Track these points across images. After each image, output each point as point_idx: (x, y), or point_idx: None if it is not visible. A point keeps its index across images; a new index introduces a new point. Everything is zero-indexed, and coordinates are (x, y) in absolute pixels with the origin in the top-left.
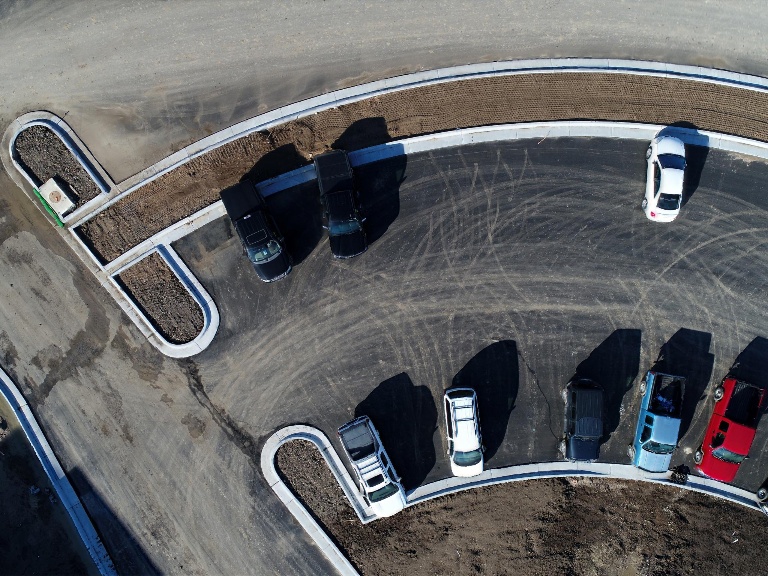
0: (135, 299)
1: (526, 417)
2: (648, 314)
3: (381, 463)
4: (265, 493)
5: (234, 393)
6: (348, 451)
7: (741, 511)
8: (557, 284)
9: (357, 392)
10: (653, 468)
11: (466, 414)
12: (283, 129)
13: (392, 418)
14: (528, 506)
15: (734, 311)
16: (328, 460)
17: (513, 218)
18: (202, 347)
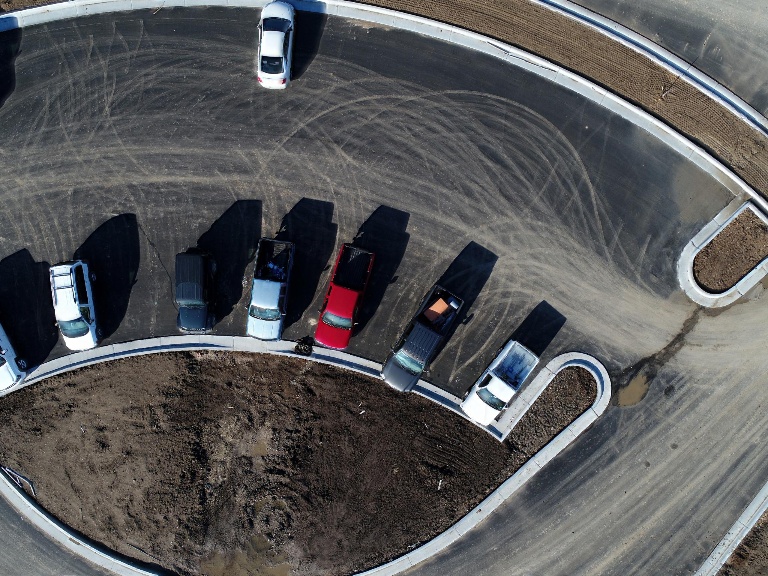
0: None
1: (148, 291)
2: (269, 184)
3: None
4: None
5: None
6: None
7: (368, 382)
8: (176, 156)
9: None
10: (262, 335)
11: (64, 282)
12: None
13: (14, 295)
14: (151, 381)
15: (357, 180)
16: None
17: (130, 90)
18: None
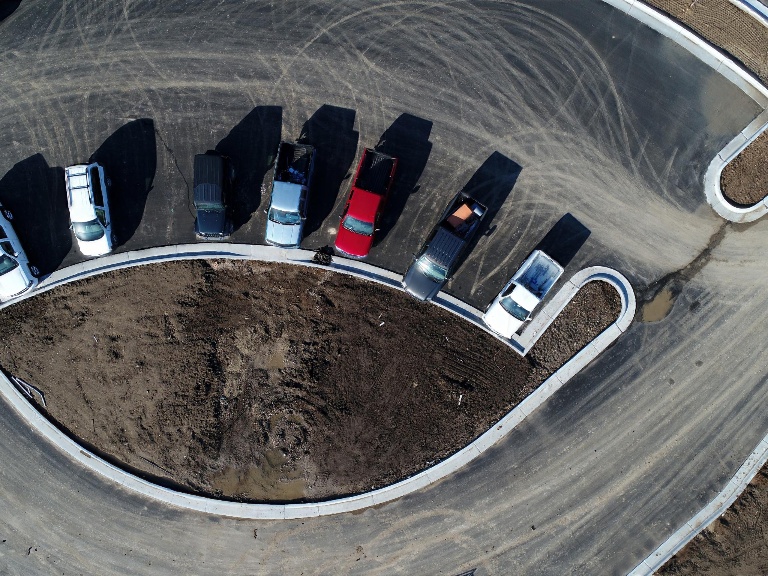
0: None
1: (164, 198)
2: (289, 90)
3: None
4: None
5: None
6: None
7: (388, 293)
8: (195, 60)
9: None
10: (281, 240)
11: (80, 182)
12: None
13: (27, 201)
14: (167, 289)
15: (379, 87)
16: None
17: None
18: None
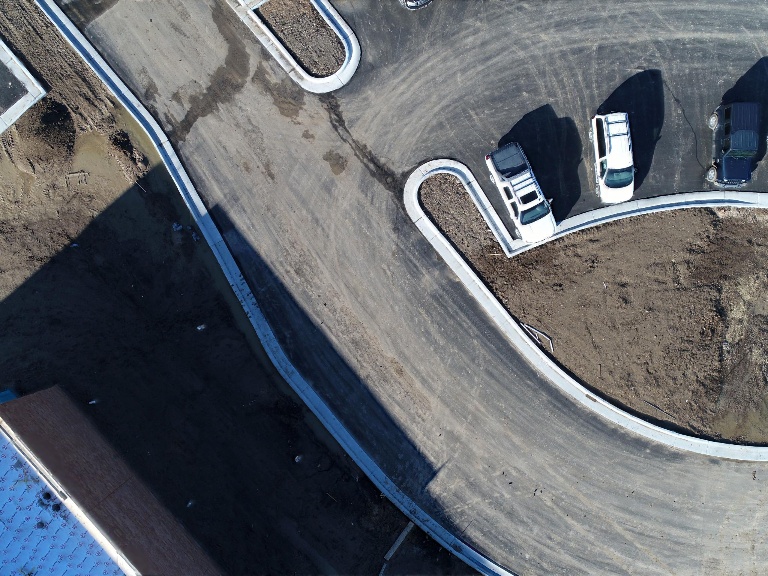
0: (275, 33)
1: (672, 147)
2: None
3: (535, 179)
4: (408, 229)
5: (376, 128)
6: (499, 171)
7: None
8: (702, 12)
9: (500, 125)
10: None
11: (620, 129)
12: None
13: (536, 151)
14: (675, 237)
15: None
16: (472, 193)
17: None
18: (344, 81)
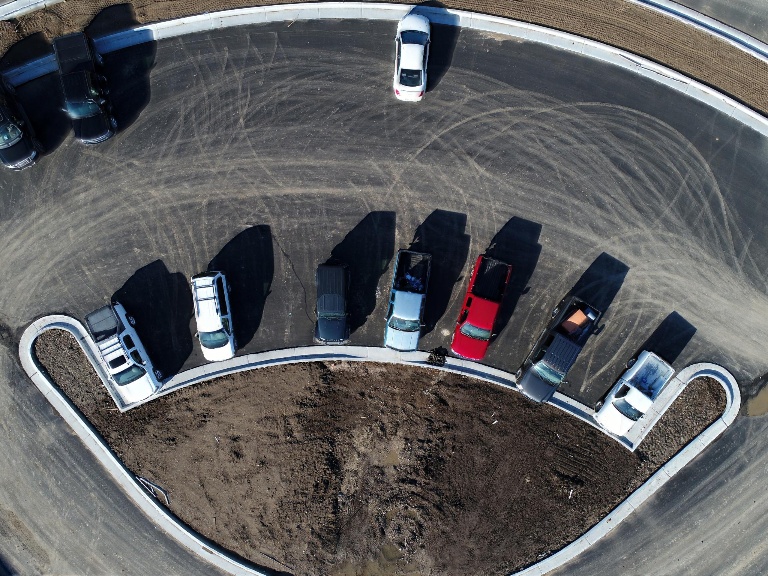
0: None
1: (282, 302)
2: (402, 196)
3: (123, 344)
4: (24, 384)
5: None
6: (93, 334)
7: (500, 392)
8: (310, 168)
9: (113, 281)
10: (400, 346)
11: (207, 293)
12: (32, 18)
13: (148, 306)
14: (285, 391)
15: (489, 191)
16: (85, 349)
17: (264, 102)
18: None
